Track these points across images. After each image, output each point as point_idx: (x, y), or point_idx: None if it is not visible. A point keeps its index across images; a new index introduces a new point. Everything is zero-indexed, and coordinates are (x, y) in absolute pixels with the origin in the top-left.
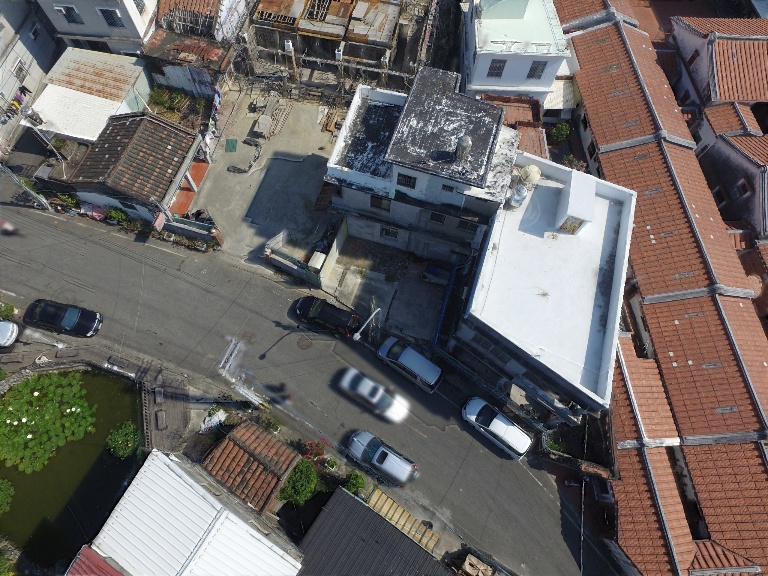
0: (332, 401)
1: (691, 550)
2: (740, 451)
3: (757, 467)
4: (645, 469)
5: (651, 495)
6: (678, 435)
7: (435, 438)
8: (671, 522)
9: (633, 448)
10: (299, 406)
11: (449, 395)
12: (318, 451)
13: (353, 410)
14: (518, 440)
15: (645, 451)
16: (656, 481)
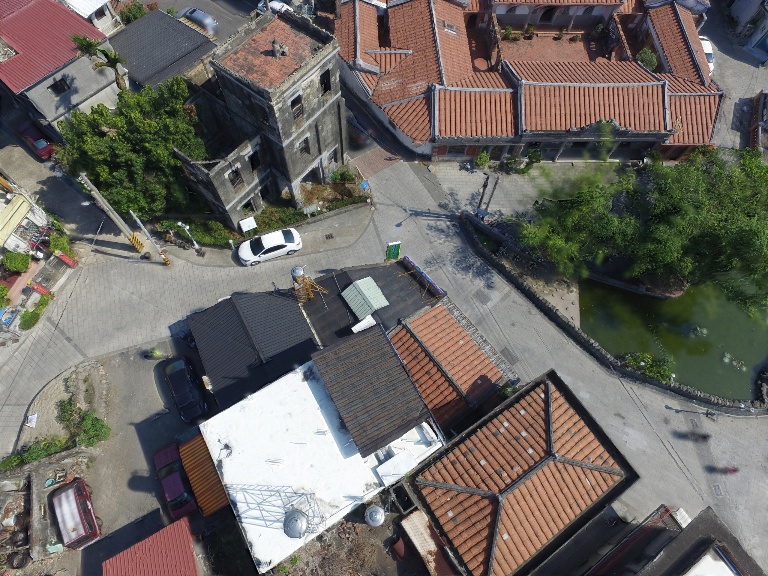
0: (172, 1)
1: (374, 46)
2: (419, 3)
3: (425, 8)
4: (354, 9)
5: (354, 19)
6: (386, 3)
7: (237, 20)
8: (363, 31)
9: (351, 2)
10: (149, 2)
11: (252, 3)
12: (152, 6)
13: (185, 6)
14: (284, 8)
15: (356, 0)
16: (360, 15)
